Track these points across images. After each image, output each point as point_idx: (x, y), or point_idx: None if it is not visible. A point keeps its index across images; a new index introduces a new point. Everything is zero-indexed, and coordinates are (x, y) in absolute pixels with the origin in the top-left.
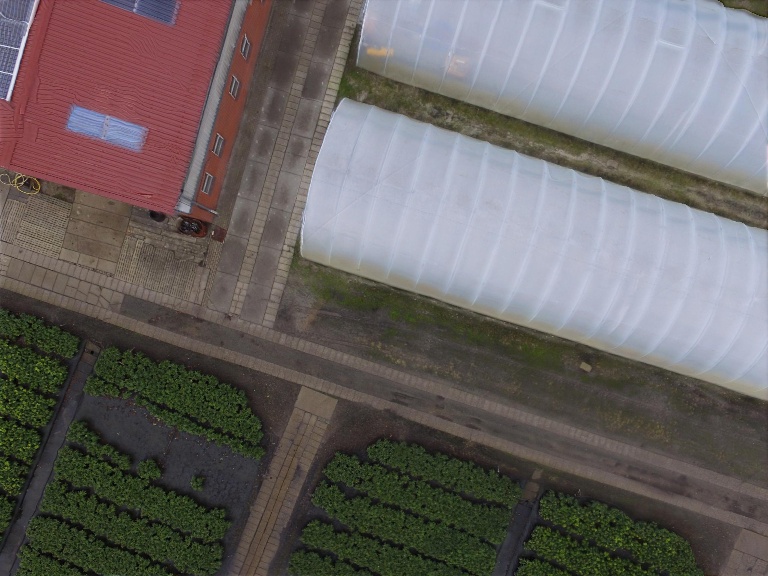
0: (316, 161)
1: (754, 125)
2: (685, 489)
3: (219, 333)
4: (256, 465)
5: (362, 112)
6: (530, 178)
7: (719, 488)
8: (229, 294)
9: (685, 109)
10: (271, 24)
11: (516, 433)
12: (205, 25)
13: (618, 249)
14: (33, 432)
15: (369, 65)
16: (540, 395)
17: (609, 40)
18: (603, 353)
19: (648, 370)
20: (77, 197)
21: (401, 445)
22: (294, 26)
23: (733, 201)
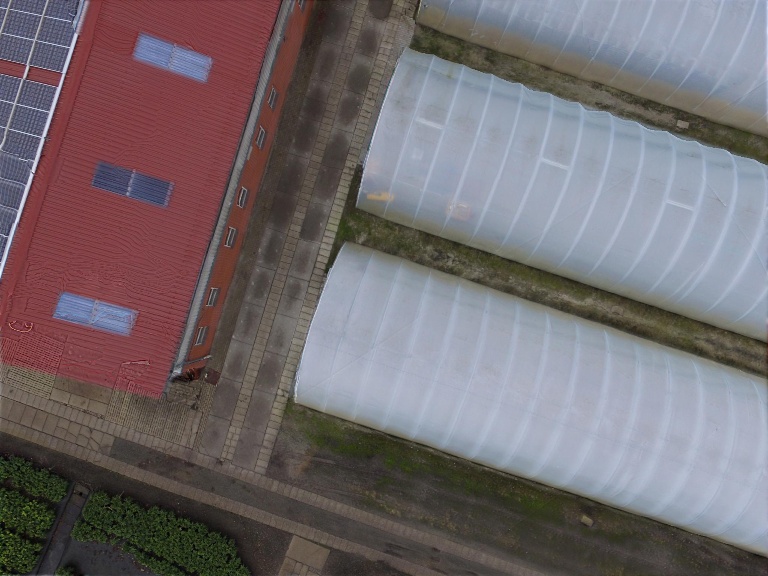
0: (311, 323)
1: (765, 288)
2: None
3: (210, 479)
4: None
5: (360, 266)
6: (531, 339)
7: None
8: (221, 439)
9: (693, 269)
10: (270, 163)
11: None
12: (199, 205)
13: (622, 418)
14: None
15: (369, 207)
16: (539, 550)
17: (615, 201)
18: (605, 507)
19: (652, 525)
20: (69, 337)
21: None
22: (293, 166)
23: (742, 351)
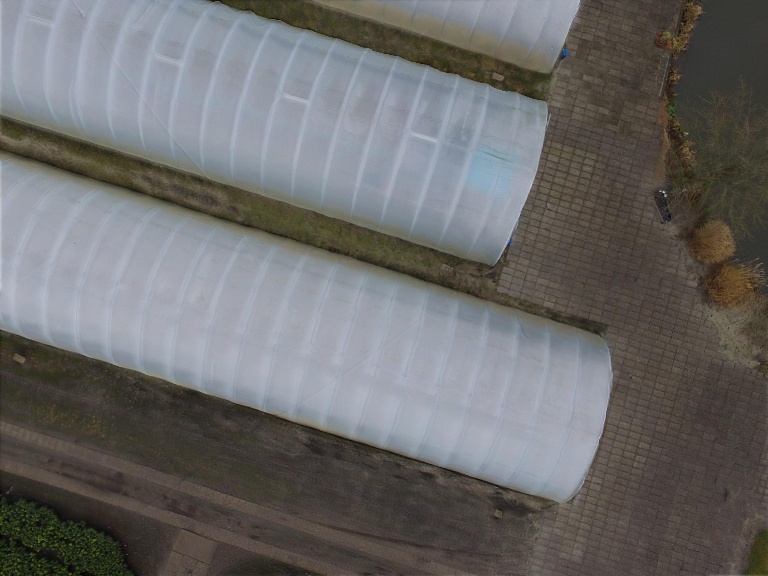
0: None
1: (138, 103)
2: (122, 487)
3: None
4: None
5: None
6: None
7: (157, 486)
8: None
9: (68, 86)
10: None
11: None
12: None
13: None
14: None
15: None
16: None
17: None
18: (38, 344)
19: (86, 362)
20: None
21: None
22: None
23: (179, 185)
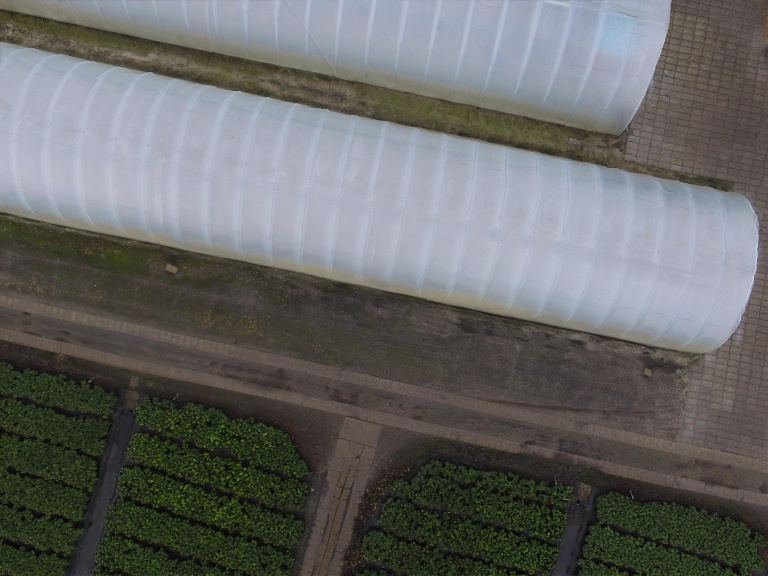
0: None
1: None
2: (284, 382)
3: None
4: None
5: None
6: (52, 75)
7: (318, 378)
8: None
9: None
10: None
11: (106, 342)
12: None
13: (136, 136)
14: None
15: None
16: (126, 301)
17: None
18: (188, 253)
19: (236, 266)
20: None
21: None
22: None
23: (308, 87)
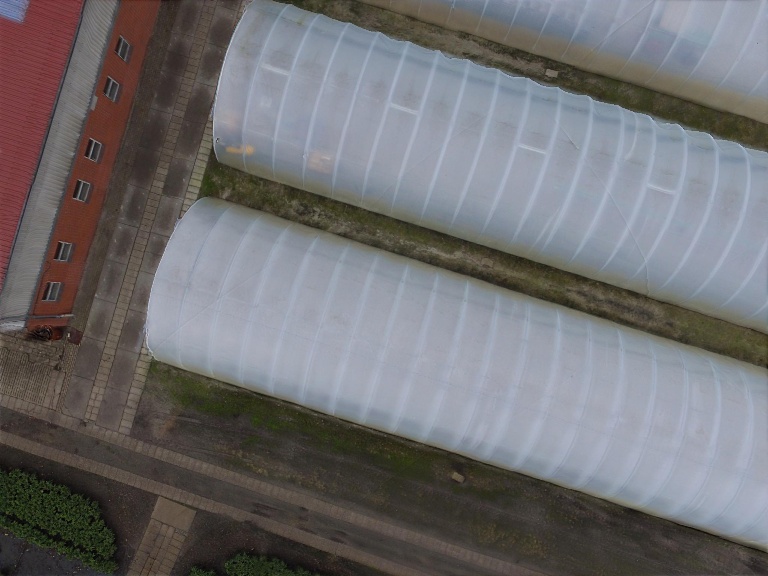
0: (155, 274)
1: (623, 232)
2: None
3: (73, 440)
4: None
5: (212, 218)
6: (385, 288)
7: None
8: (84, 399)
9: (550, 215)
10: (132, 119)
11: (384, 548)
12: (16, 147)
13: (474, 366)
14: None
15: (231, 162)
16: (409, 507)
17: (466, 145)
18: (477, 463)
19: (525, 481)
20: None
21: (261, 560)
22: (155, 121)
23: (615, 302)
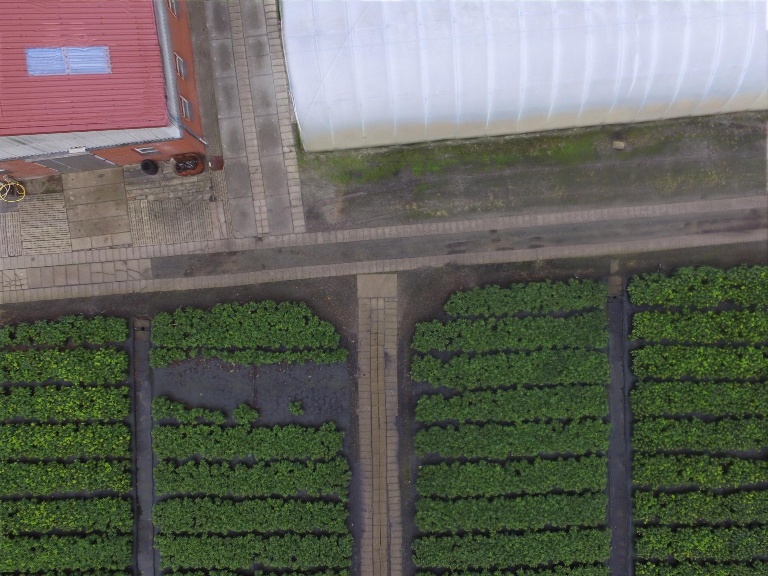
0: (281, 34)
1: None
2: (759, 222)
3: (256, 258)
4: (345, 369)
5: None
6: None
7: None
8: (250, 216)
9: None
10: None
11: (578, 235)
12: None
13: (606, 1)
14: (119, 425)
15: None
16: (586, 190)
17: None
18: (629, 125)
19: (678, 124)
20: (64, 184)
21: (474, 291)
22: None
23: None
